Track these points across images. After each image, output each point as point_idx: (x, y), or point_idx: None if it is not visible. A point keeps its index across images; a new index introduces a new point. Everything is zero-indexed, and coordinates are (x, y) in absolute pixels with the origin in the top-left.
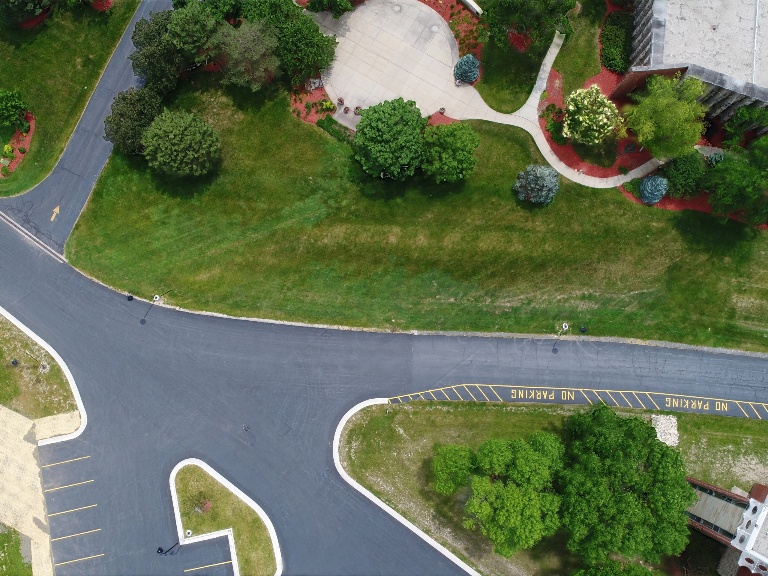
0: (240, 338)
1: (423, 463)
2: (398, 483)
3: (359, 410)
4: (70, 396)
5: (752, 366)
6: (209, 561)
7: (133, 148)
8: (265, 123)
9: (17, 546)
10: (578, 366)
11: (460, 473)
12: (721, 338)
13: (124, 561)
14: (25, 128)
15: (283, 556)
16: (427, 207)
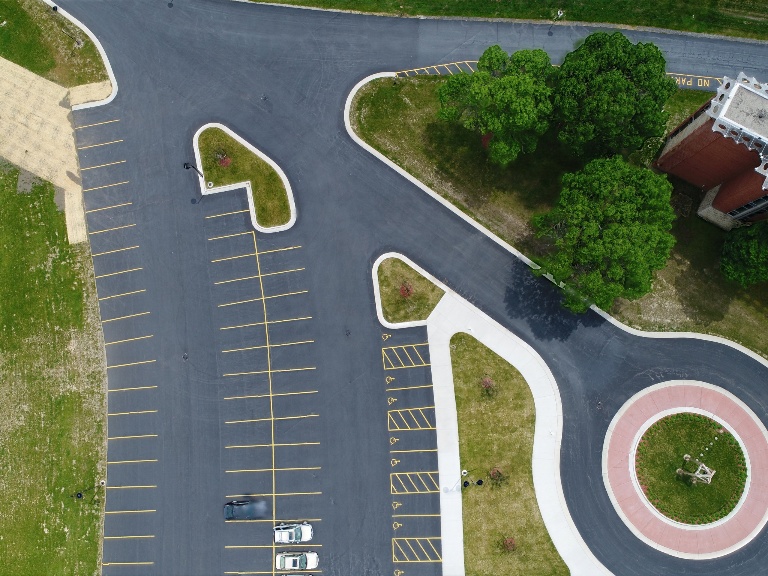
0: (260, 20)
1: (427, 127)
2: (404, 144)
3: (369, 81)
4: (102, 68)
5: (732, 48)
6: (229, 209)
7: None
8: None
9: (52, 197)
10: (571, 47)
11: (462, 89)
12: (704, 24)
13: (150, 209)
14: None
15: (297, 206)
16: None
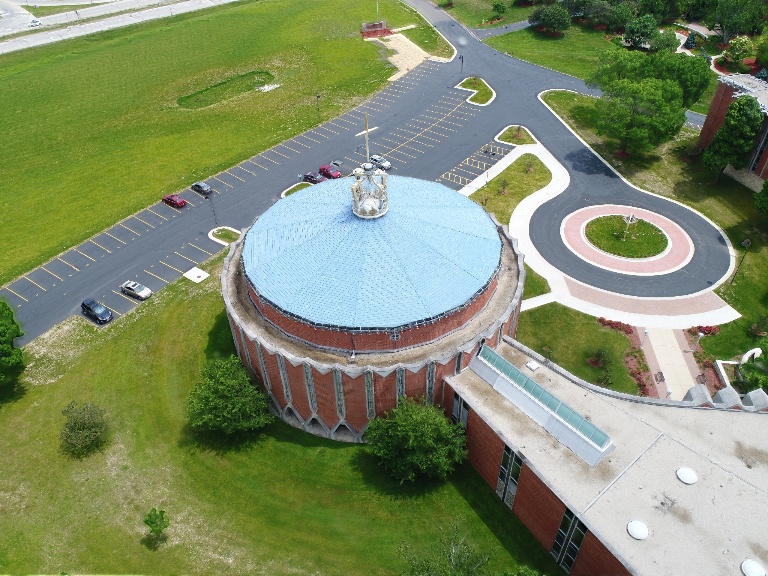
0: None
1: (578, 106)
2: None
3: (562, 90)
4: None
5: None
6: None
7: (537, 16)
8: None
9: None
10: None
11: None
12: None
13: None
14: (498, 18)
15: None
16: None
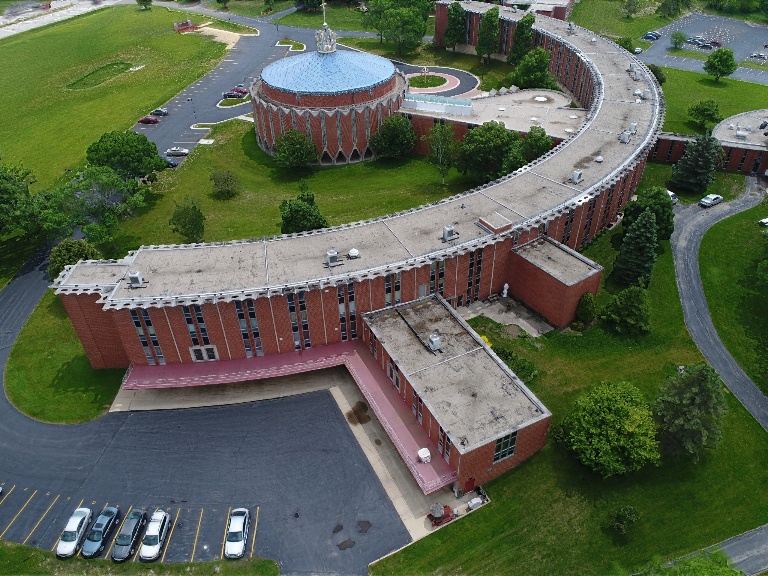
0: None
1: (359, 42)
2: None
3: None
4: None
5: None
6: None
7: (301, 2)
8: None
9: None
10: None
11: None
12: None
13: None
14: (271, 9)
15: None
16: None
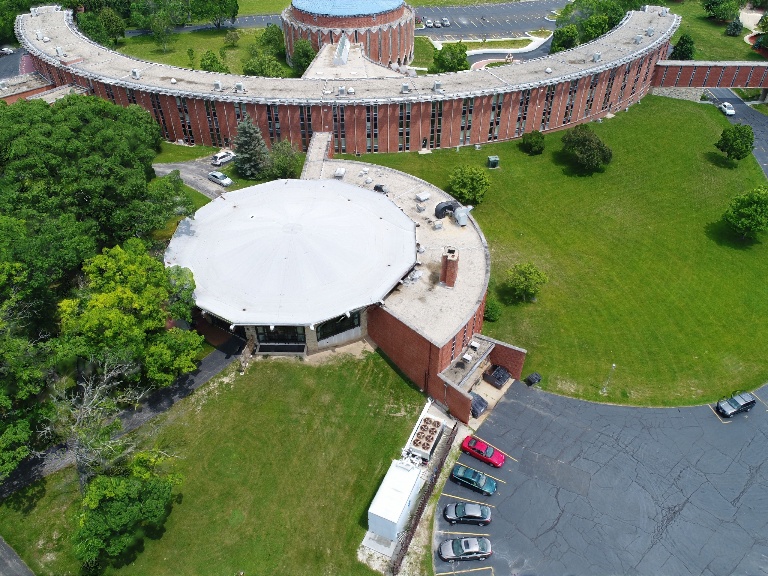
0: None
1: None
2: None
3: None
4: None
5: None
6: None
7: None
8: (700, 8)
9: None
10: None
11: None
12: None
13: None
14: None
15: None
16: (702, 25)
